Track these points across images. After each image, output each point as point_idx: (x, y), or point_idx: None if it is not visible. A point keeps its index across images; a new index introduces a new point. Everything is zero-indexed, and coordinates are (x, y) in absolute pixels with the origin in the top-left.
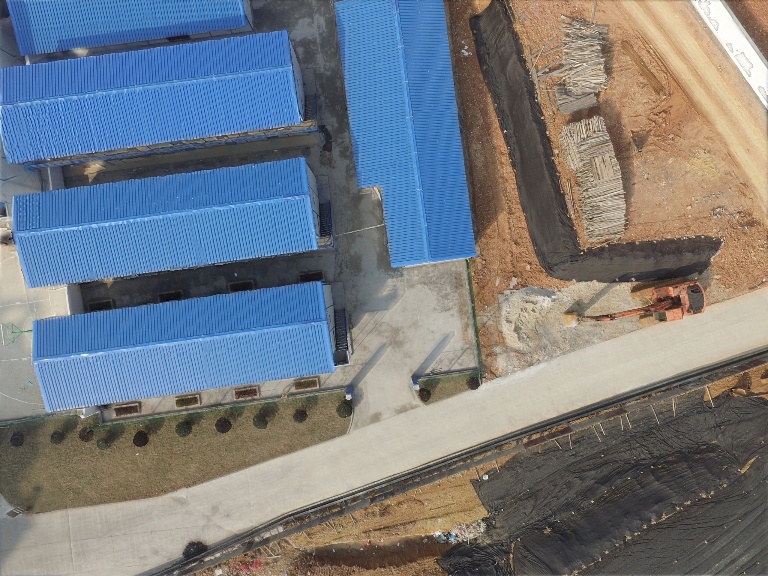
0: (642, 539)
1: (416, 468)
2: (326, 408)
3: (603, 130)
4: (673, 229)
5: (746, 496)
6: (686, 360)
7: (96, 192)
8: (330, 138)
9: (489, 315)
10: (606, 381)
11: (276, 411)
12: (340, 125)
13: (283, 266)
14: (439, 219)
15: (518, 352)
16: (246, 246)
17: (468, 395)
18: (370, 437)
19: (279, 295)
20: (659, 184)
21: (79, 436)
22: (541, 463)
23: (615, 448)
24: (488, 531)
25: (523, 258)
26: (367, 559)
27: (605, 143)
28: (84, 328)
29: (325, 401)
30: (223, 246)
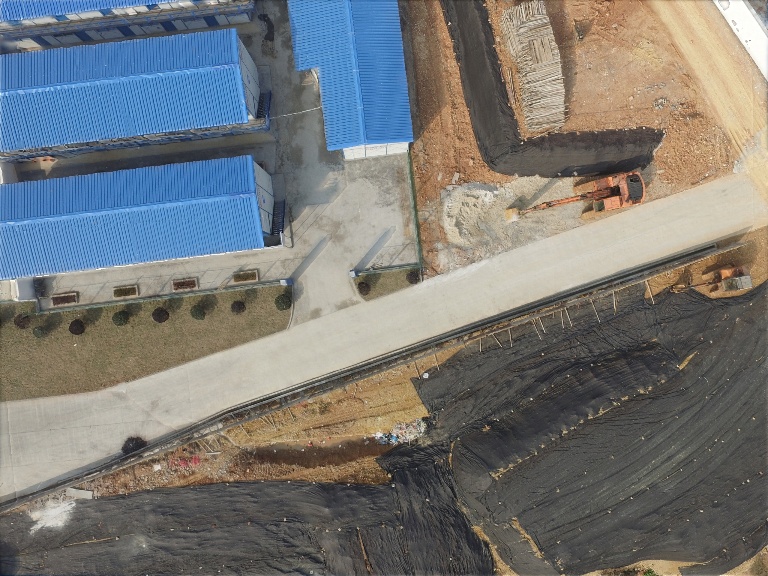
0: (579, 434)
1: (356, 365)
2: (266, 302)
3: (543, 13)
4: (615, 120)
5: (684, 392)
6: (628, 257)
7: (24, 59)
8: (272, 27)
9: (431, 210)
10: (547, 278)
11: (215, 304)
12: (282, 14)
13: (223, 157)
14: (376, 102)
15: (459, 248)
16: (175, 117)
17: (409, 292)
18: (310, 333)
19: (208, 168)
20: (601, 74)
21: (14, 322)
22: (481, 361)
23: (556, 347)
24: (428, 431)
25: (466, 154)
26: (308, 459)
27: (544, 26)
28: (11, 197)
29: (265, 295)
30: (152, 116)
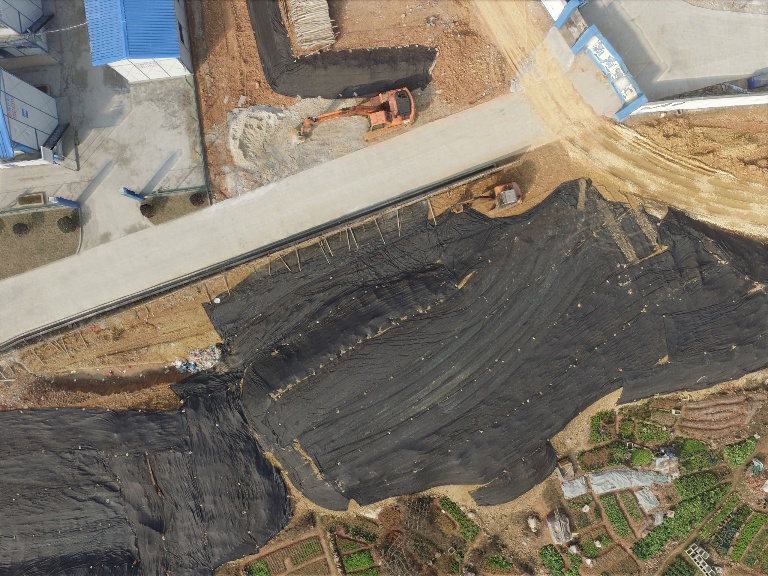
0: (358, 354)
1: (146, 290)
2: (53, 226)
3: None
4: (388, 38)
5: (463, 312)
6: (411, 179)
7: None
8: None
9: (217, 133)
10: (334, 201)
11: (2, 228)
12: None
13: None
14: (139, 17)
15: (246, 171)
16: None
17: (198, 216)
18: (100, 258)
19: None
20: None
21: None
22: (271, 286)
23: (343, 270)
24: (224, 358)
25: (253, 77)
26: (106, 387)
27: None
28: None
29: (52, 219)
30: None
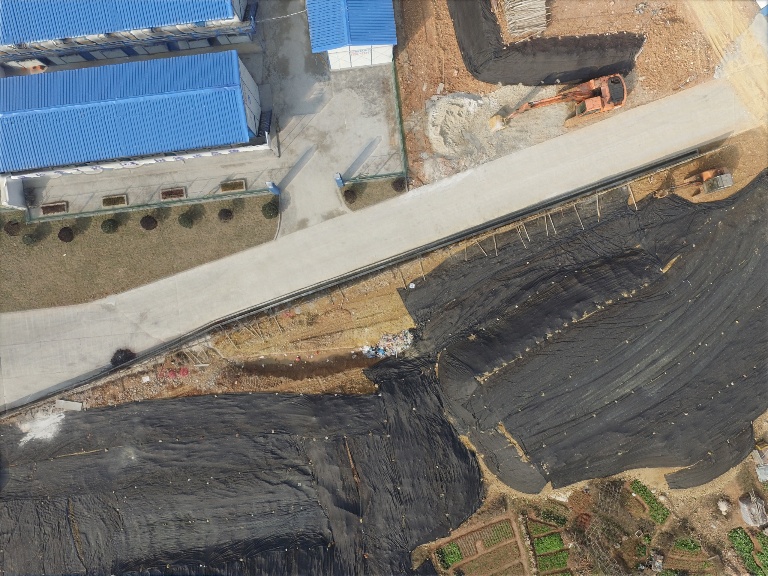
0: (563, 338)
1: (343, 275)
2: (253, 212)
3: None
4: (596, 25)
5: (667, 296)
6: (611, 164)
7: None
8: None
9: (416, 120)
10: (532, 187)
11: (203, 214)
12: None
13: None
14: (360, 4)
15: (444, 158)
16: (161, 12)
17: (395, 202)
18: (297, 244)
19: (194, 62)
20: None
21: (4, 228)
22: (467, 271)
23: (540, 255)
24: (415, 343)
25: (451, 64)
26: (295, 372)
27: None
28: None
29: (252, 205)
30: (138, 11)
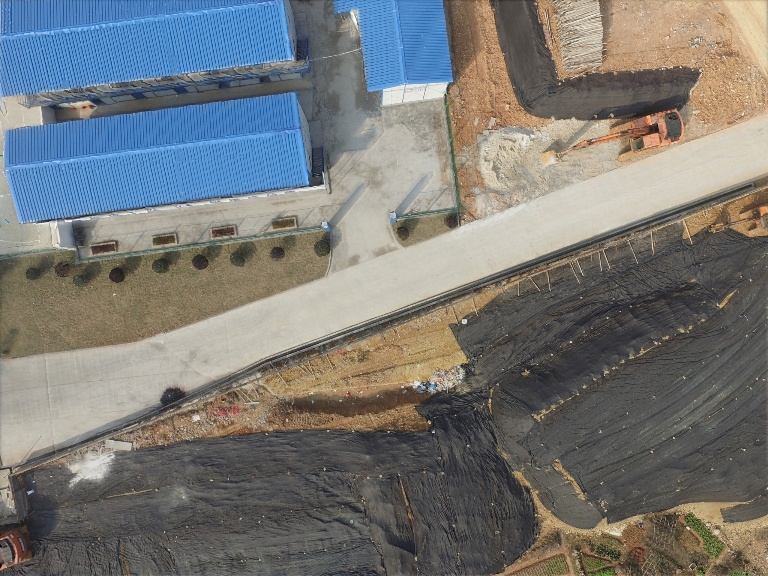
0: (620, 374)
1: (394, 311)
2: (304, 249)
3: None
4: (651, 60)
5: (724, 331)
6: (665, 198)
7: None
8: None
9: (468, 155)
10: (585, 222)
11: (254, 252)
12: None
13: None
14: (415, 42)
15: (497, 193)
16: (220, 55)
17: (447, 238)
18: (348, 280)
19: (253, 105)
20: (637, 14)
21: (55, 270)
22: (520, 306)
23: (594, 290)
24: (467, 378)
25: (502, 99)
26: (346, 408)
27: None
28: (56, 137)
29: (303, 242)
30: (196, 55)
